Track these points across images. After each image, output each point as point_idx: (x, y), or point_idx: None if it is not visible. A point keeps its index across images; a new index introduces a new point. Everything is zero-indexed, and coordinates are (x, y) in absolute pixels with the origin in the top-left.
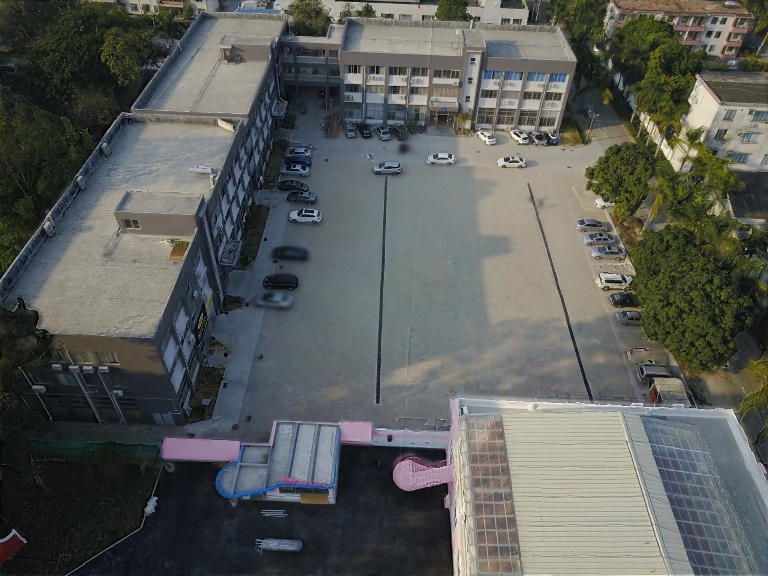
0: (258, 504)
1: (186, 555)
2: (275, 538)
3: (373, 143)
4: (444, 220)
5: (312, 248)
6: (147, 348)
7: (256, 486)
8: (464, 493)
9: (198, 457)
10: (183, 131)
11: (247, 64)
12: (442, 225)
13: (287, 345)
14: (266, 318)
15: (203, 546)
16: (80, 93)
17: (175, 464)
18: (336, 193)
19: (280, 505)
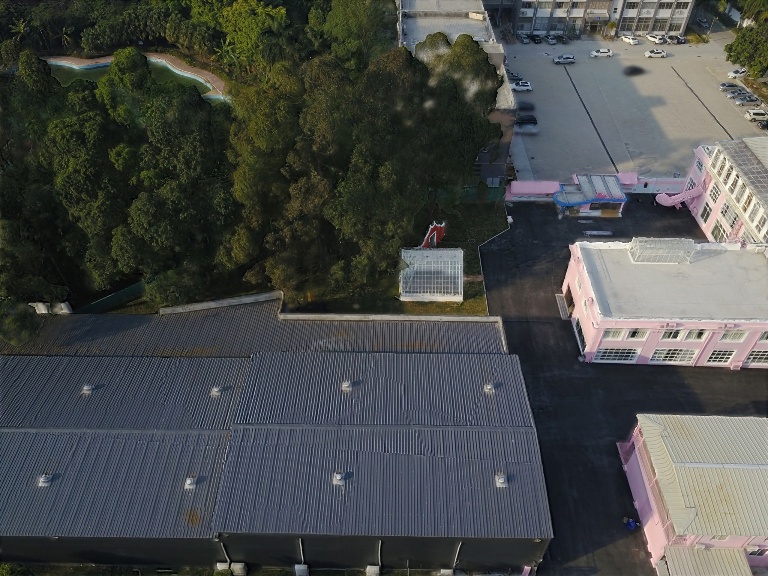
0: (574, 218)
1: (544, 238)
2: (594, 230)
3: (544, 46)
4: (620, 88)
5: (534, 105)
6: (509, 118)
7: (579, 201)
8: (727, 179)
9: (534, 192)
10: (446, 21)
11: None
12: (620, 91)
13: (547, 152)
14: (524, 140)
15: (552, 235)
16: None
17: (512, 203)
18: (533, 75)
19: (588, 218)
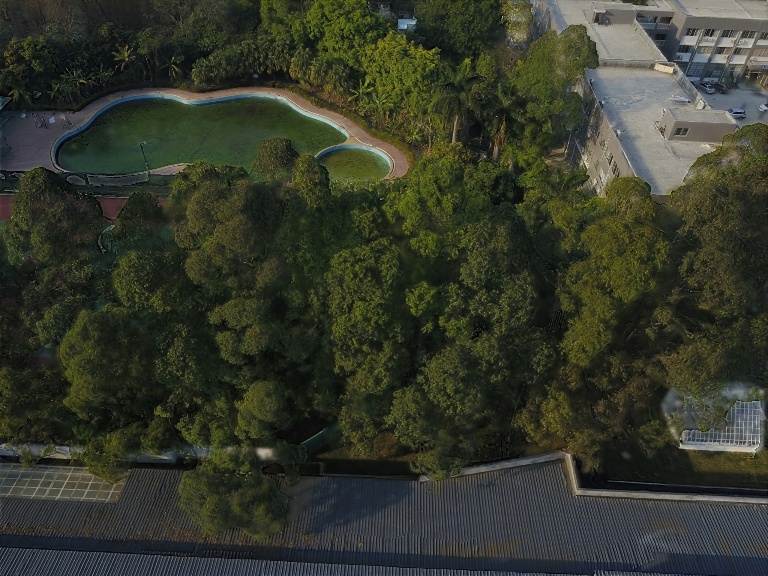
0: None
1: None
2: None
3: None
4: None
5: None
6: None
7: None
8: None
9: None
10: (629, 73)
11: (614, 26)
12: None
13: None
14: None
15: None
16: (486, 49)
17: None
18: None
19: None
